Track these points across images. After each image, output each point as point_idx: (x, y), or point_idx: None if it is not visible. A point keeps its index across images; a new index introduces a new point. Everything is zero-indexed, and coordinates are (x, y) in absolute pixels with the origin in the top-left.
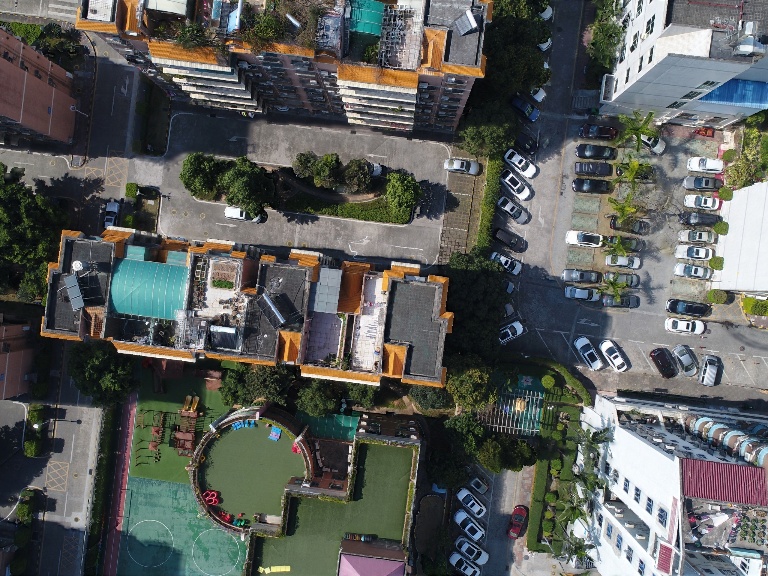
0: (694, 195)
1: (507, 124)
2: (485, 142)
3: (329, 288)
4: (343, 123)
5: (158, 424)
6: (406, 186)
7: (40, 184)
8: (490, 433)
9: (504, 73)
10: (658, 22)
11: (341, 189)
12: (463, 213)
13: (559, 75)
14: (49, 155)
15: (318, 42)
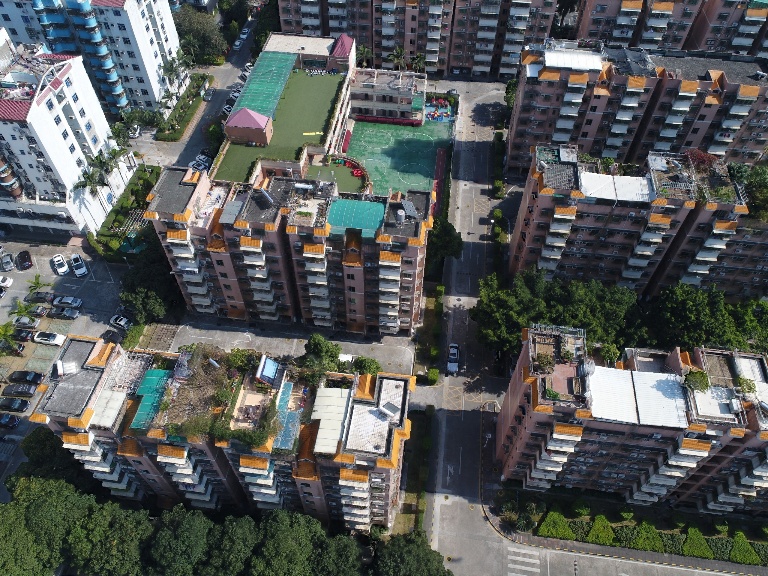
0: None
1: None
2: None
3: (230, 213)
4: None
5: None
6: None
7: None
8: None
9: None
10: None
11: None
12: None
13: None
14: None
15: None
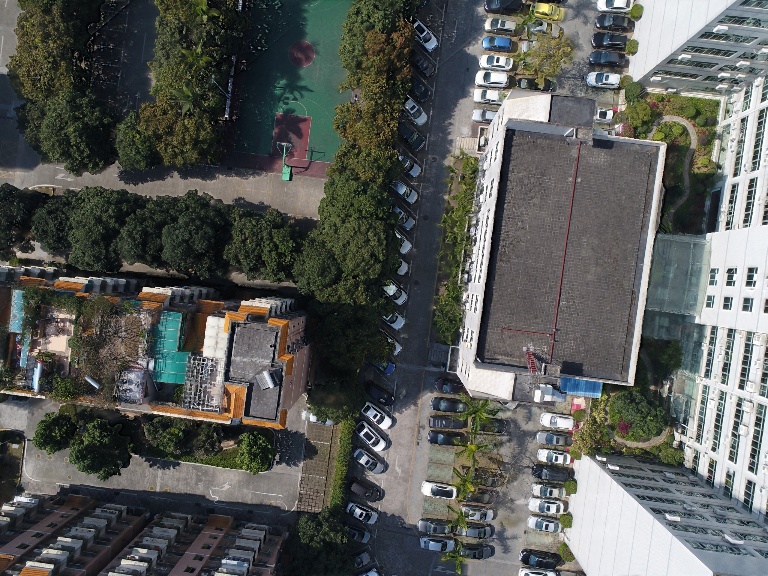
0: (546, 450)
1: (346, 406)
2: None
3: None
4: None
5: None
6: (254, 454)
7: None
8: None
9: (343, 358)
10: (473, 347)
11: None
12: (322, 461)
13: (416, 327)
14: None
15: (121, 395)
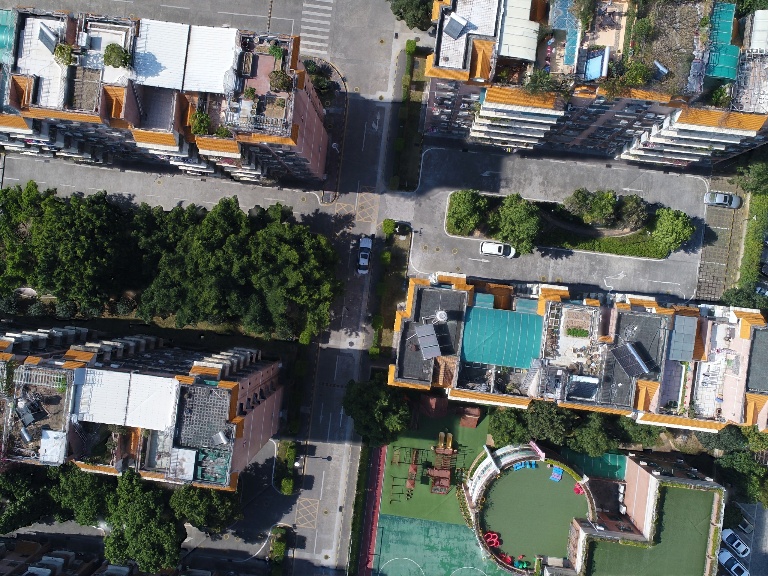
0: None
1: None
2: (767, 178)
3: (685, 336)
4: (598, 157)
5: (410, 461)
6: (683, 222)
7: (290, 220)
8: (765, 473)
9: None
10: None
11: (598, 224)
12: (722, 247)
13: None
14: (300, 191)
15: None
